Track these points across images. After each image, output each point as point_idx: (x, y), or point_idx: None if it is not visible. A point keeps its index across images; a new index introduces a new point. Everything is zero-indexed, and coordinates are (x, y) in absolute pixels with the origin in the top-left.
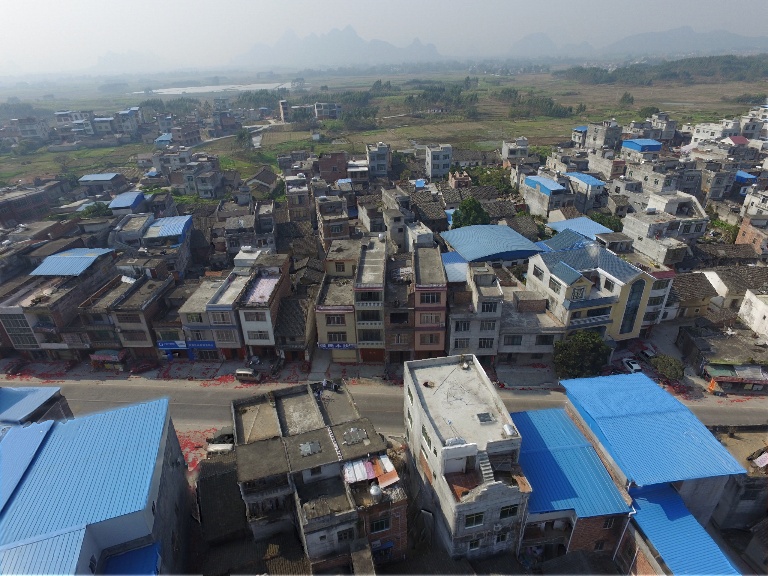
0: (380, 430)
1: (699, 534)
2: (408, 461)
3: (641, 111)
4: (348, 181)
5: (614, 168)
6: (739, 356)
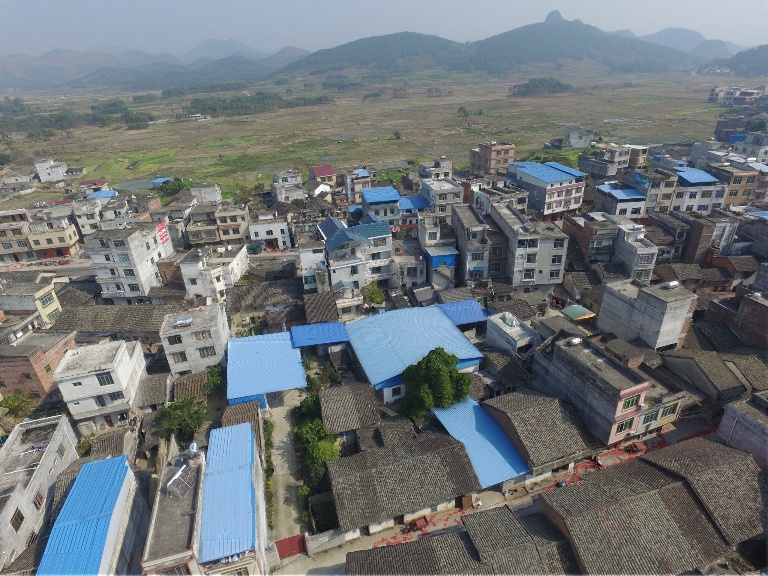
0: None
1: None
2: None
3: None
4: None
5: None
6: None
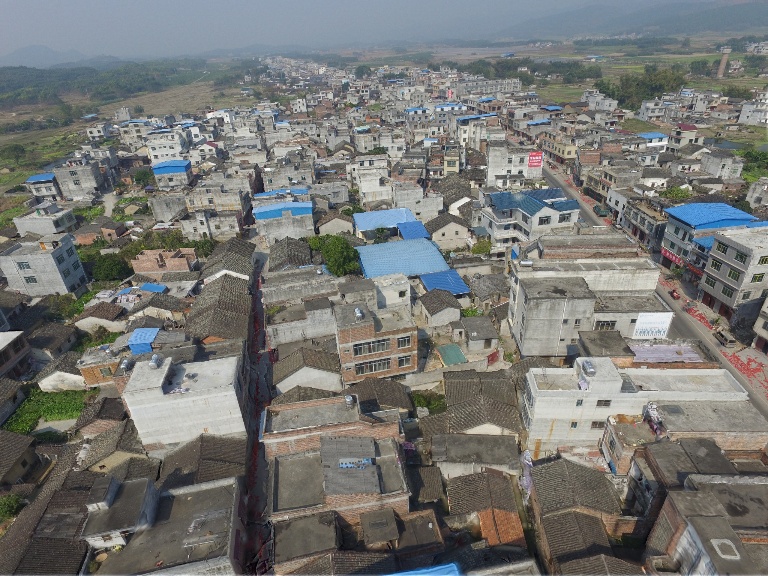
0: (705, 339)
1: (753, 223)
2: (744, 313)
3: (2, 152)
4: (153, 330)
5: (249, 183)
6: None
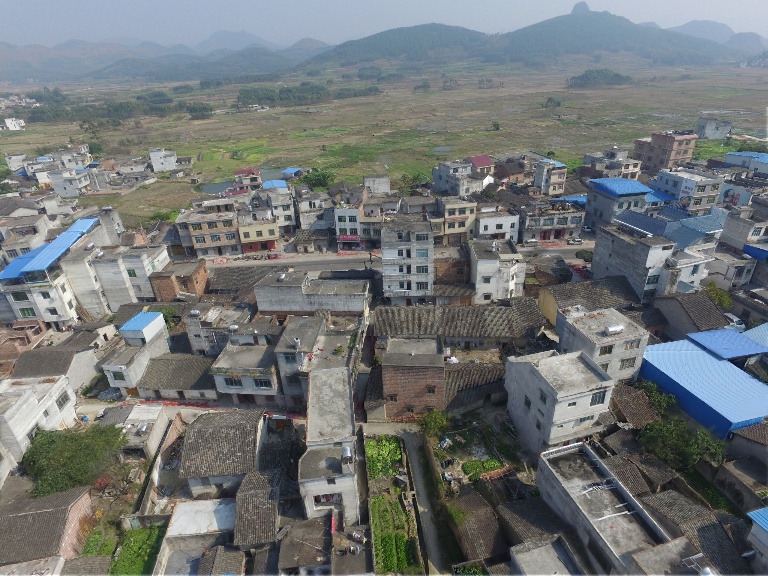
0: None
1: None
2: None
3: None
4: None
5: None
6: (541, 258)
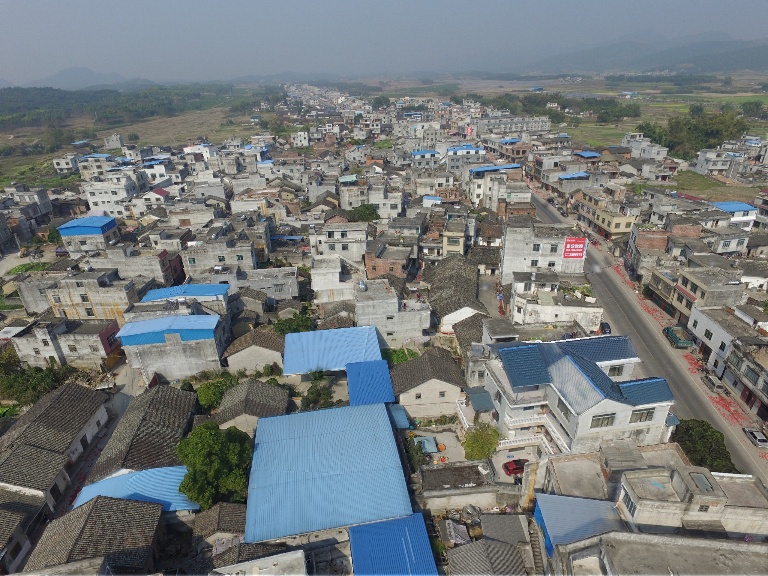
0: None
1: None
2: None
3: None
4: None
5: (161, 263)
6: None
